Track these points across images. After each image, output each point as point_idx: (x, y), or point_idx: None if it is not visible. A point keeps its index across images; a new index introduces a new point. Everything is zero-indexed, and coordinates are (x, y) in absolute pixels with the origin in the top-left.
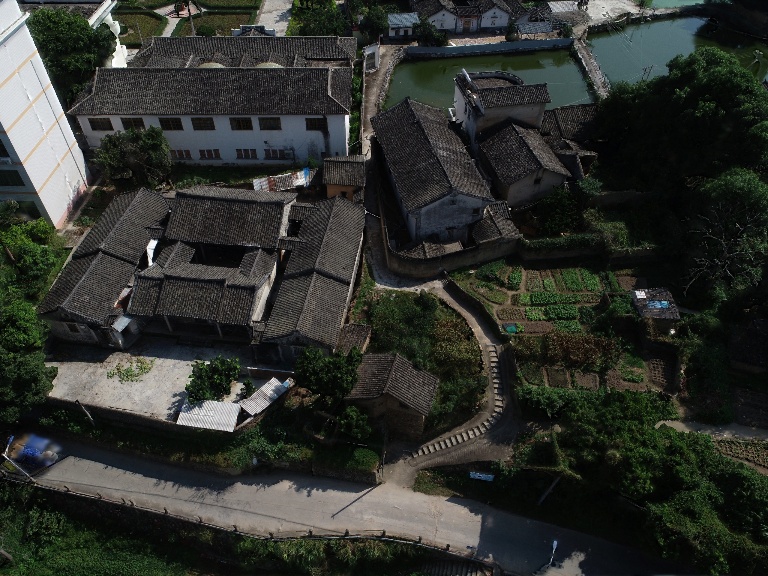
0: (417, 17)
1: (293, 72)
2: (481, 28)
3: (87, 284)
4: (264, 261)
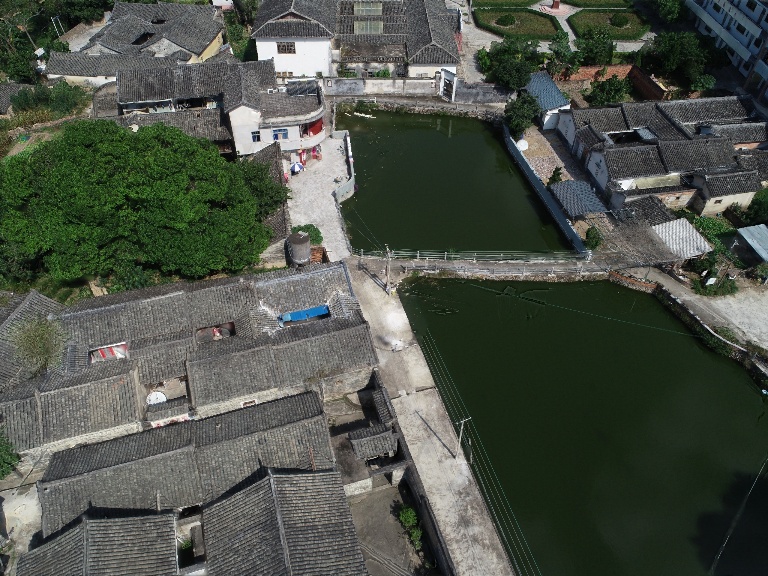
0: (559, 105)
1: (290, 0)
2: (588, 169)
3: (135, 7)
4: (133, 49)
